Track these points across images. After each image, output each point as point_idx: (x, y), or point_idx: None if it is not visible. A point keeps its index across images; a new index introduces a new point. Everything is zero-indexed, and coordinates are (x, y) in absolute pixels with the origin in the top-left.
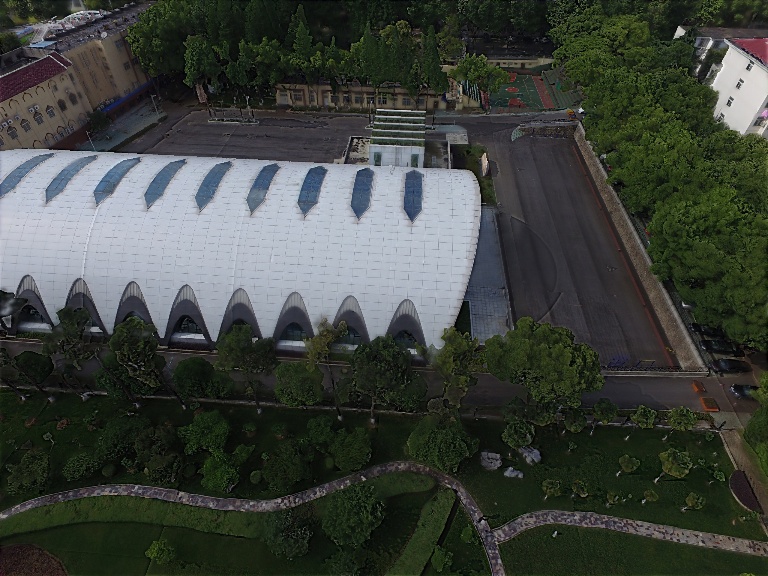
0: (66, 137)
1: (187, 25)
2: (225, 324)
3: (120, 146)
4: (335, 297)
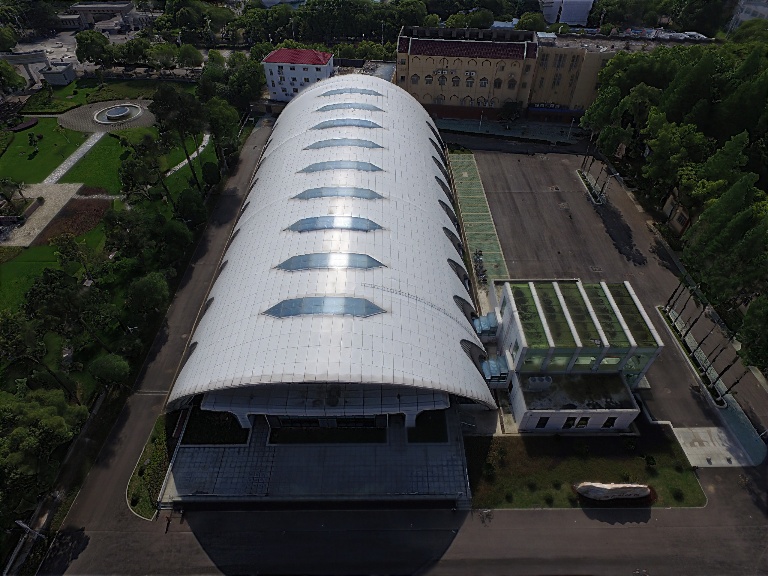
0: (482, 107)
1: (670, 75)
2: None
3: (496, 137)
4: None
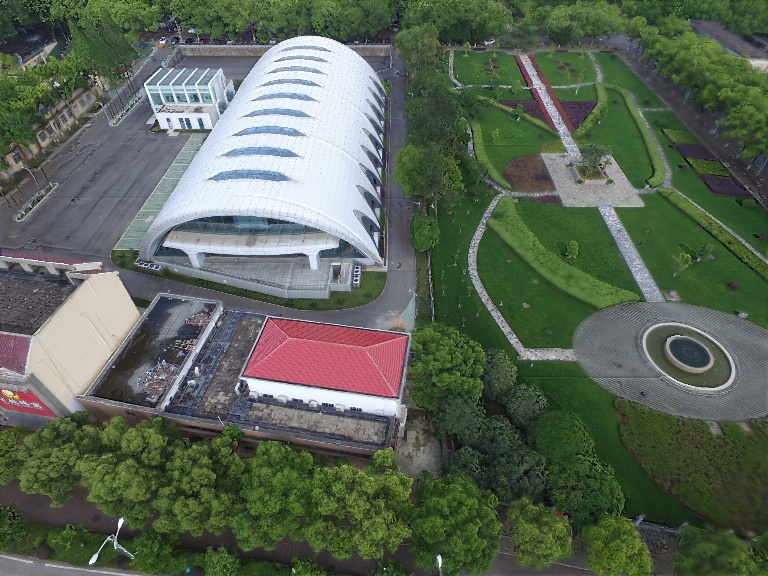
0: None
1: None
2: (378, 134)
3: None
4: (368, 91)
